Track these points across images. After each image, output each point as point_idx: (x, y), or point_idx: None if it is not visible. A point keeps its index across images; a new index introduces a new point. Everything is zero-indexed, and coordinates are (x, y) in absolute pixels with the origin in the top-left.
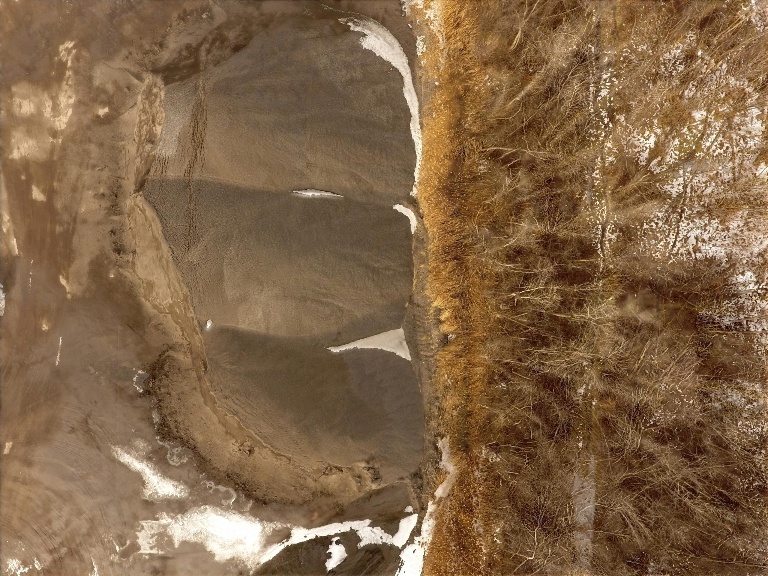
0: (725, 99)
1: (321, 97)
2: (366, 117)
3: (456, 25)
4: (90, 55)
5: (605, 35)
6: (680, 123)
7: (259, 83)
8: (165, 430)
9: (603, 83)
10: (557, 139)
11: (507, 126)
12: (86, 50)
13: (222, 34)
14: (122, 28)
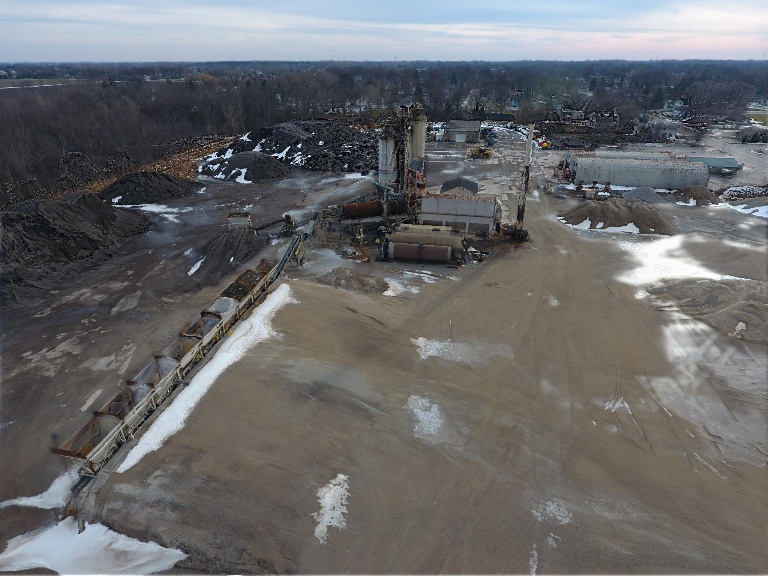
0: None
1: None
2: None
3: None
4: None
5: None
6: None
7: None
8: None
9: None
10: None
11: None
12: None
13: None
14: None
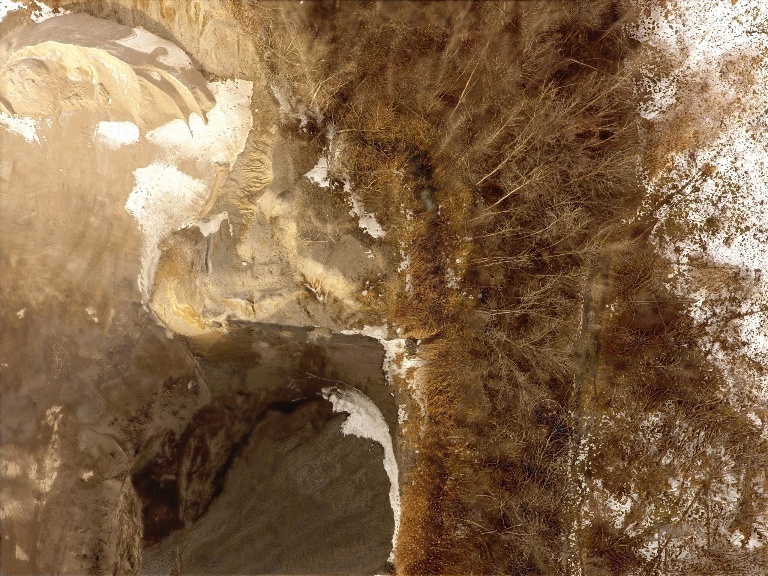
0: (702, 467)
1: (299, 519)
2: (344, 514)
3: (438, 391)
4: (76, 420)
5: (585, 401)
6: (656, 491)
7: (236, 539)
8: None
9: (582, 448)
10: (534, 510)
11: (484, 503)
12: (73, 415)
13: (204, 441)
14: (109, 394)
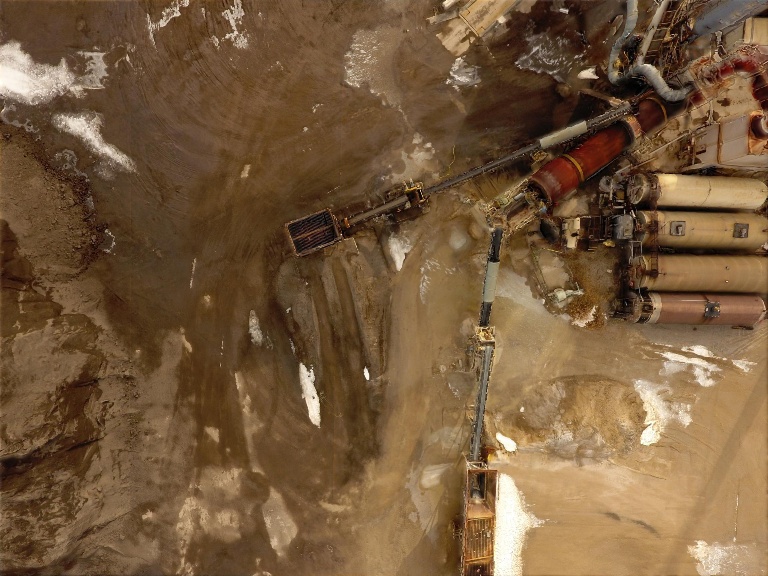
0: None
1: None
2: None
3: None
4: (162, 569)
5: None
6: None
7: None
8: (79, 189)
9: None
10: None
11: None
12: (166, 574)
13: None
14: None
